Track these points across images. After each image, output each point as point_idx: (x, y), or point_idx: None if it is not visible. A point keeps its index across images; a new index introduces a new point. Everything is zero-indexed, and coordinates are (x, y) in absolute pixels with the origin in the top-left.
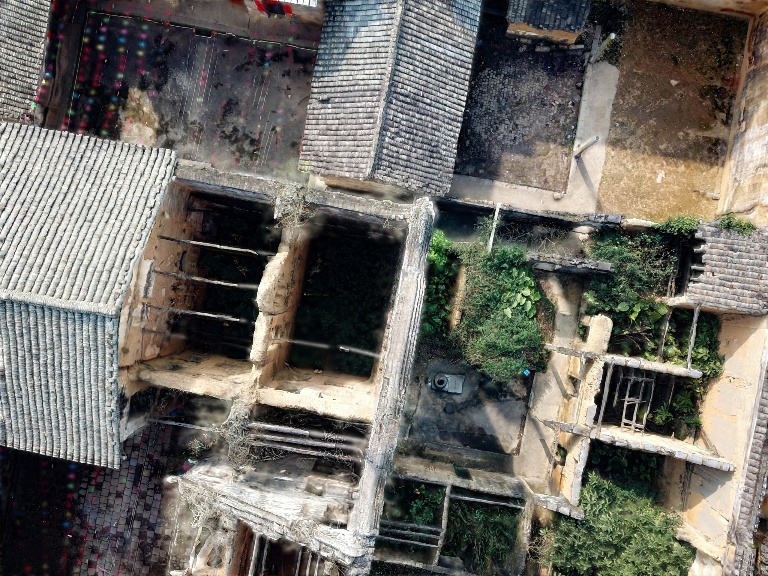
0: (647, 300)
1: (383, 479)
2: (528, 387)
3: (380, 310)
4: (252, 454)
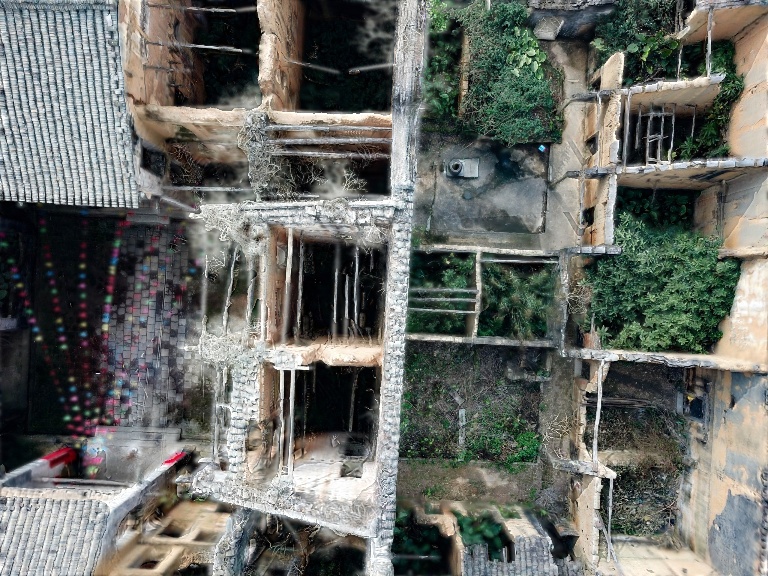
0: (656, 37)
1: (413, 138)
2: (545, 163)
3: (385, 83)
4: (273, 164)
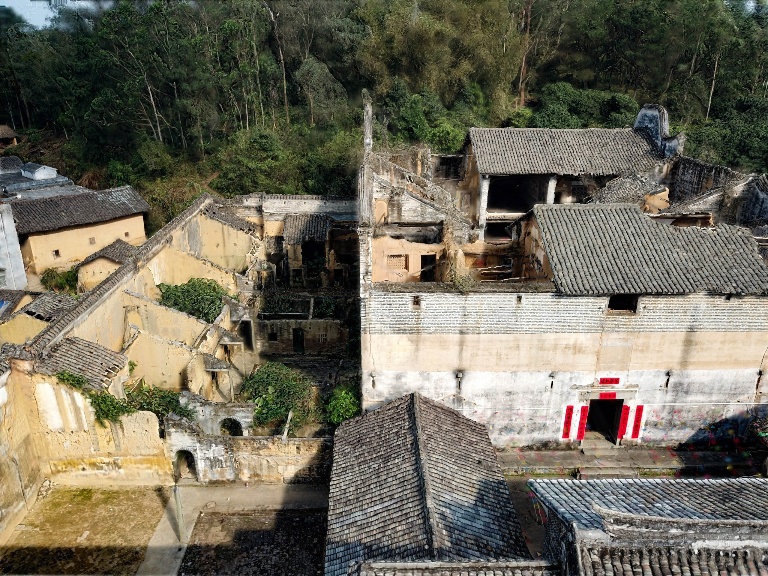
0: None
1: None
2: None
3: None
4: None
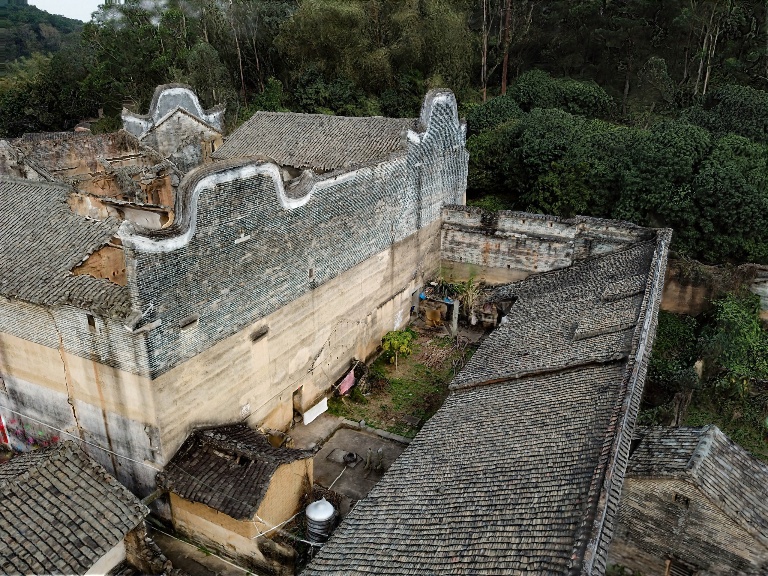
0: None
1: None
2: None
3: None
4: None
